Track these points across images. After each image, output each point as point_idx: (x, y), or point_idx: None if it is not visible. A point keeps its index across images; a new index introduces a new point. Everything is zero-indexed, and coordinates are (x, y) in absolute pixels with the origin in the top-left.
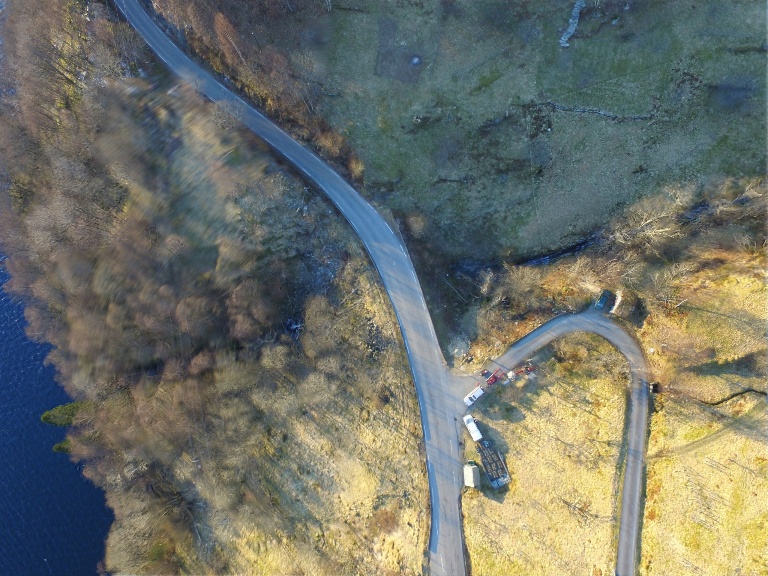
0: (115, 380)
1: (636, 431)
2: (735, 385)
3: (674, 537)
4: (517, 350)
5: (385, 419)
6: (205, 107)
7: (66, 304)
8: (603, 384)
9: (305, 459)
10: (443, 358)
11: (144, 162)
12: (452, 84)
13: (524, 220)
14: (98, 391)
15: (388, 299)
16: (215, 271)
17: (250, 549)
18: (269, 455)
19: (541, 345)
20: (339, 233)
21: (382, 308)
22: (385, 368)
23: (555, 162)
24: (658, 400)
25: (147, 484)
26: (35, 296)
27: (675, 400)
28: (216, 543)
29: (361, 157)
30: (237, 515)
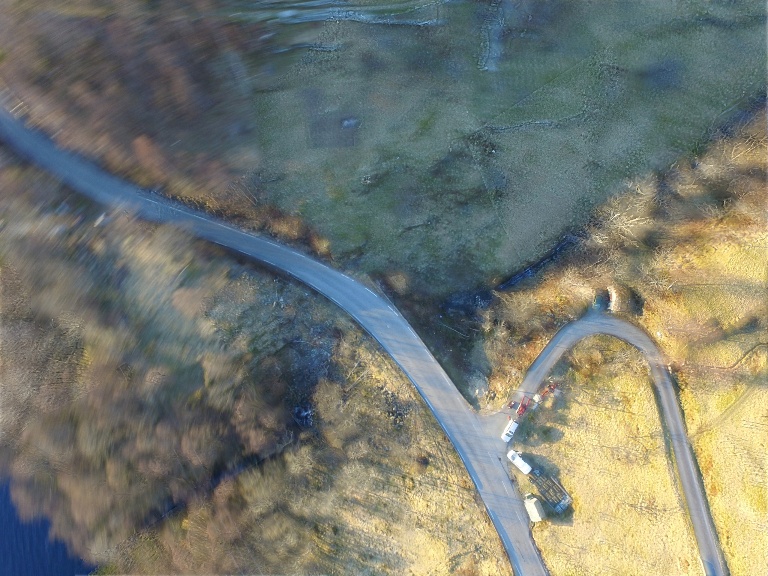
0: (136, 534)
1: (671, 415)
2: (743, 344)
3: (741, 506)
4: (535, 372)
5: (431, 481)
6: (143, 231)
7: (53, 470)
8: (625, 380)
9: (363, 545)
10: (467, 403)
11: (92, 302)
12: (388, 136)
13: (496, 241)
14: (121, 551)
15: (394, 363)
16: (205, 387)
17: None
18: (324, 553)
19: (555, 360)
20: (323, 312)
21: (391, 374)
22: (414, 431)
23: (508, 179)
24: (680, 379)
25: None
26: None
27: (695, 374)
28: None
29: (321, 233)
30: None
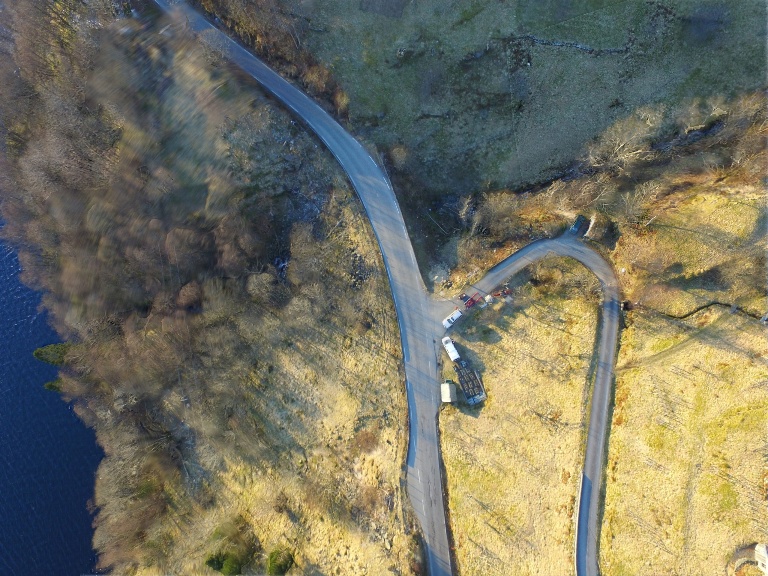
0: (106, 317)
1: (606, 345)
2: (701, 299)
3: (639, 439)
4: (495, 275)
5: (367, 344)
6: (195, 43)
7: (59, 247)
8: (576, 303)
9: (290, 388)
10: (423, 284)
11: (136, 102)
12: (435, 18)
13: (504, 155)
14: (89, 328)
15: (371, 229)
16: (205, 210)
17: (236, 482)
18: (255, 386)
19: (518, 269)
20: (325, 167)
21: (365, 238)
22: (367, 296)
23: (534, 97)
24: (628, 317)
25: (136, 419)
26: (29, 238)
27: (644, 315)
28: (203, 479)
29: (346, 91)
30: (223, 441)
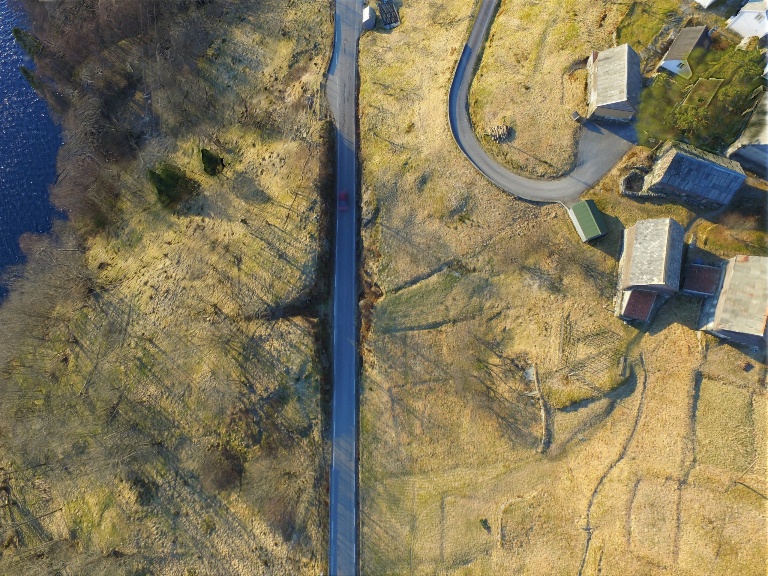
0: (82, 3)
1: None
2: None
3: (514, 18)
4: None
5: None
6: None
7: None
8: None
9: (238, 51)
10: None
11: None
12: None
13: None
14: (66, 14)
15: None
16: None
17: (185, 156)
18: (209, 57)
19: None
20: None
21: None
22: None
23: None
24: None
25: None
26: None
27: None
28: (156, 163)
29: None
30: (175, 89)
